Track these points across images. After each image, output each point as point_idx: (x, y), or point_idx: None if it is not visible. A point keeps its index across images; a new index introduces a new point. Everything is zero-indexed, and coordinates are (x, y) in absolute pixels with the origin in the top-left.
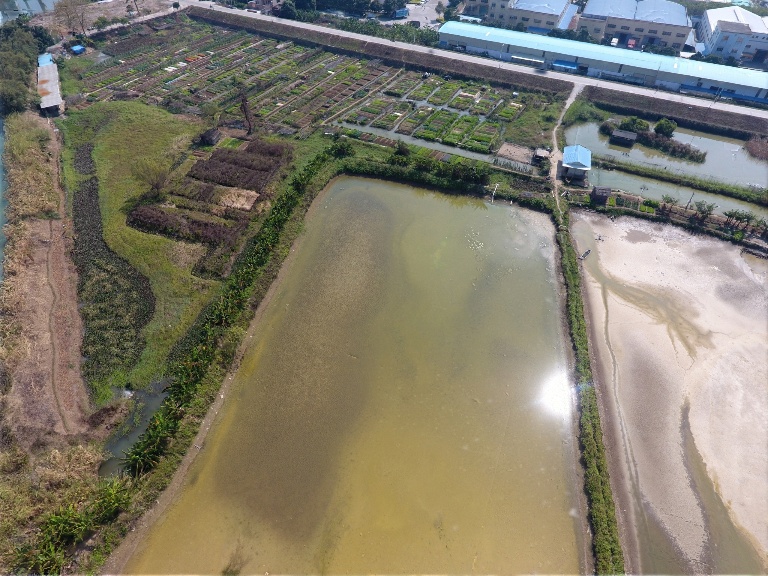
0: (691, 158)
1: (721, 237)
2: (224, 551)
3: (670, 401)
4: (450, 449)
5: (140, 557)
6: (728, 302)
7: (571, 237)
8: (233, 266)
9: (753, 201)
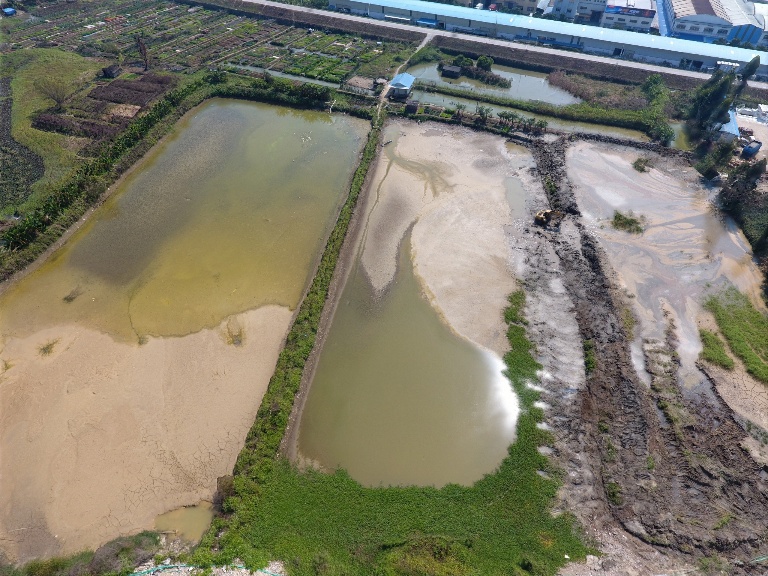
0: (500, 85)
1: (494, 132)
2: (67, 289)
3: (405, 219)
4: (239, 243)
5: (9, 293)
6: (479, 169)
7: (381, 133)
8: None
9: (531, 110)
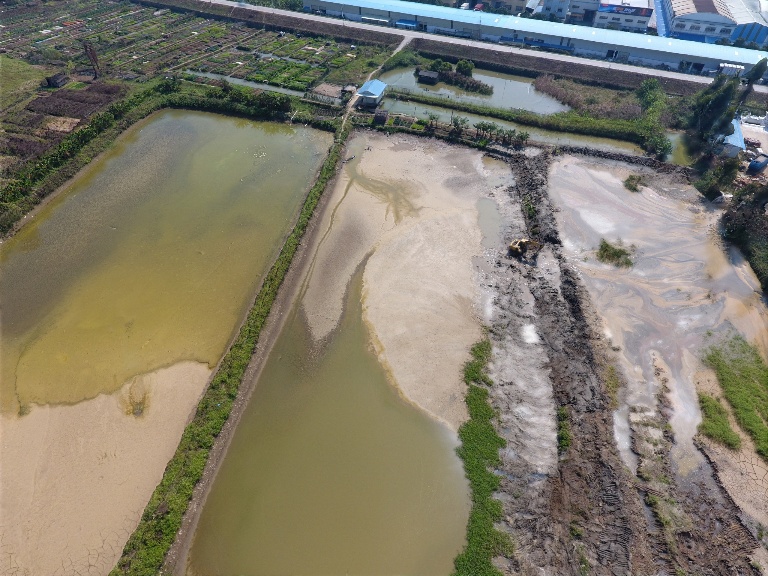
0: (480, 91)
1: (470, 145)
2: None
3: (360, 250)
4: (163, 282)
5: None
6: (449, 188)
7: (344, 148)
8: None
9: (513, 120)
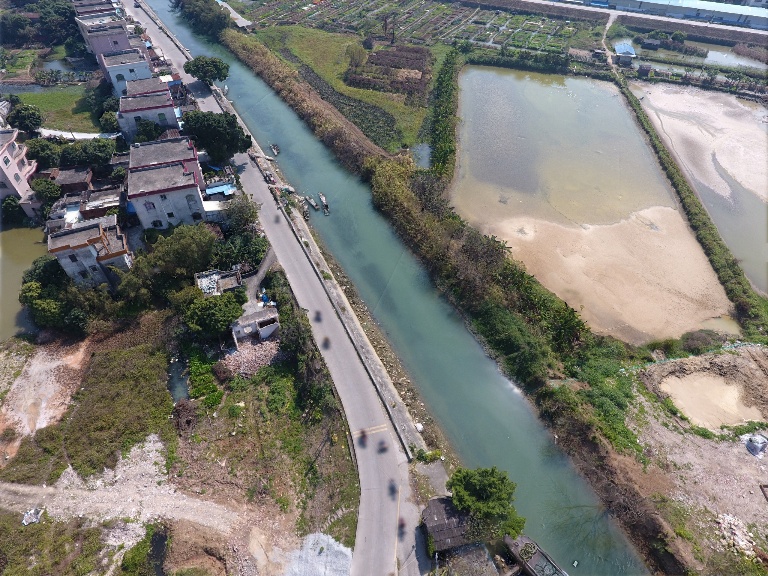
0: (698, 55)
1: (723, 90)
2: (495, 196)
3: (705, 152)
4: (592, 167)
5: (455, 198)
6: (731, 117)
7: None
8: (428, 103)
9: None
